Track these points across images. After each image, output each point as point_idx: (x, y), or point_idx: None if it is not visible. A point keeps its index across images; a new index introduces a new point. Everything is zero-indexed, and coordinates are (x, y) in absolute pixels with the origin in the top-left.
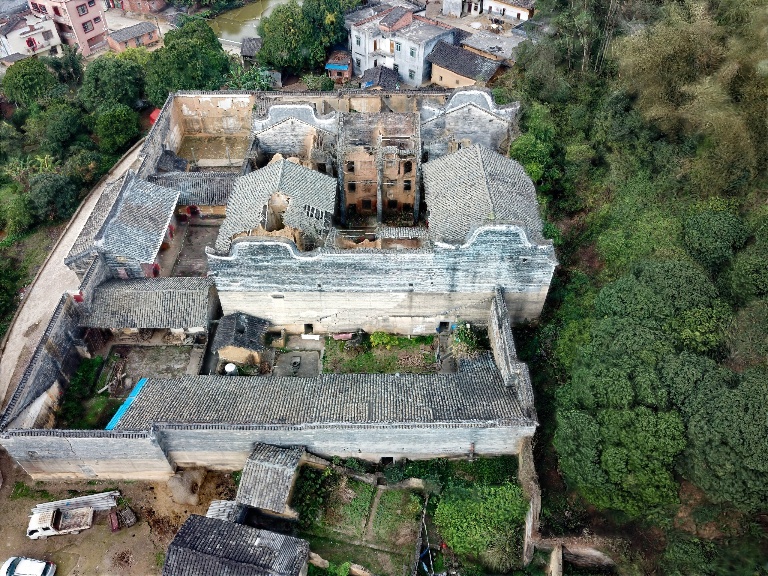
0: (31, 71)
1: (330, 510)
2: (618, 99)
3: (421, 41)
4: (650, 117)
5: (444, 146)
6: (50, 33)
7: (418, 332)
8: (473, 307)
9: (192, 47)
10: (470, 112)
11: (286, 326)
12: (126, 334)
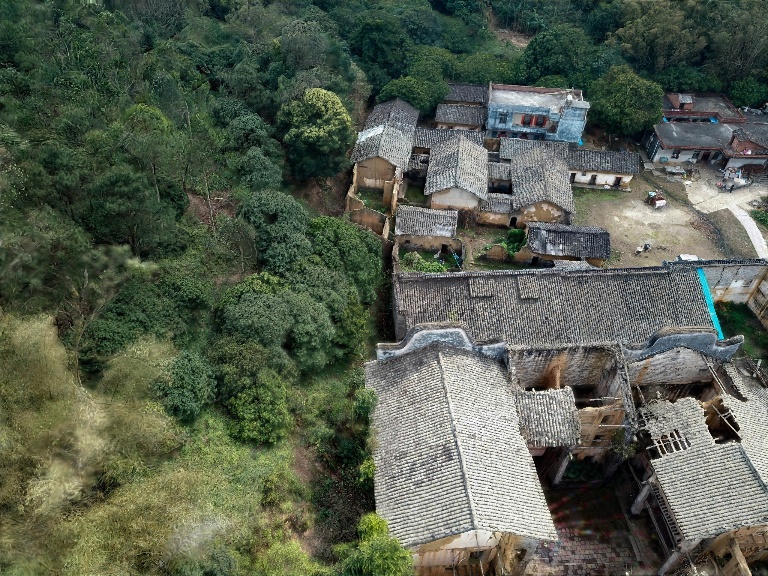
0: None
1: None
2: None
3: None
4: None
5: None
6: None
7: None
8: None
9: None
10: None
11: None
12: None
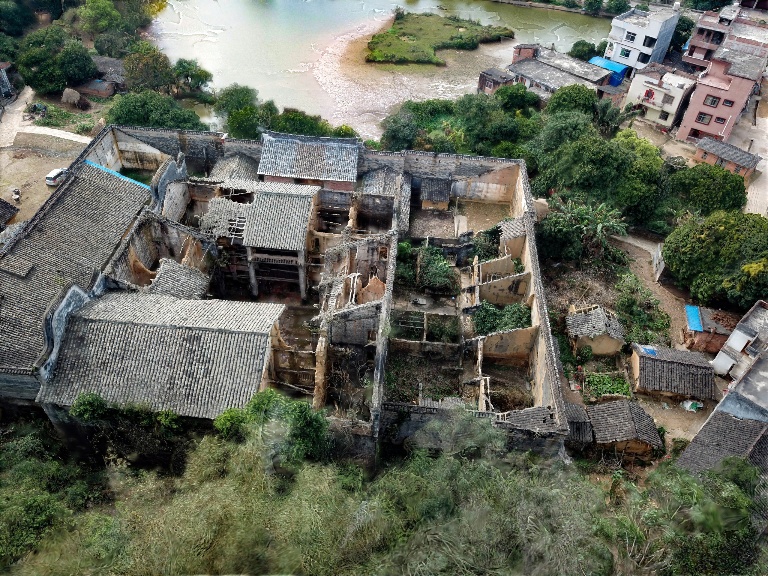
0: (572, 95)
1: None
2: None
3: None
4: None
5: None
6: (672, 99)
7: None
8: None
9: (611, 158)
10: None
11: None
12: None
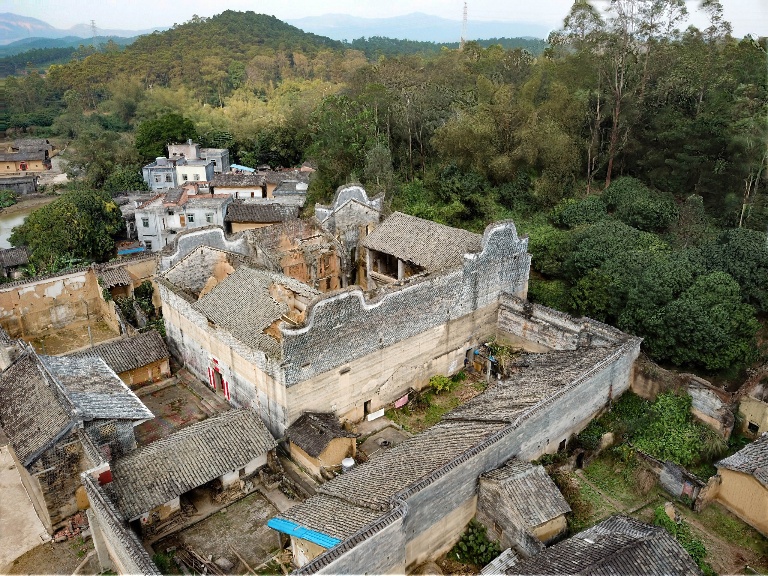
0: None
1: (577, 505)
2: (453, 169)
3: (216, 206)
4: (494, 165)
5: (356, 232)
6: None
7: (451, 372)
8: (487, 323)
9: None
10: (352, 208)
11: (348, 415)
12: (163, 520)
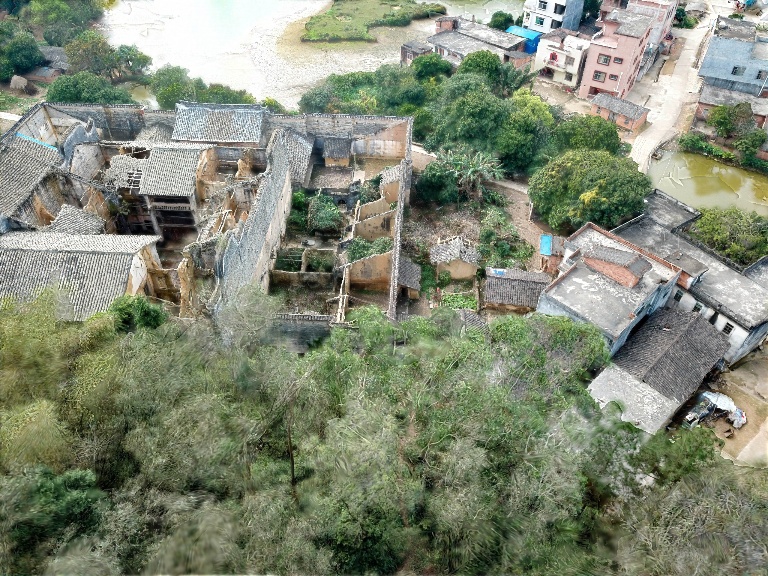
0: (476, 60)
1: None
2: None
3: None
4: None
5: None
6: (573, 61)
7: None
8: None
9: (488, 111)
10: None
11: None
12: None
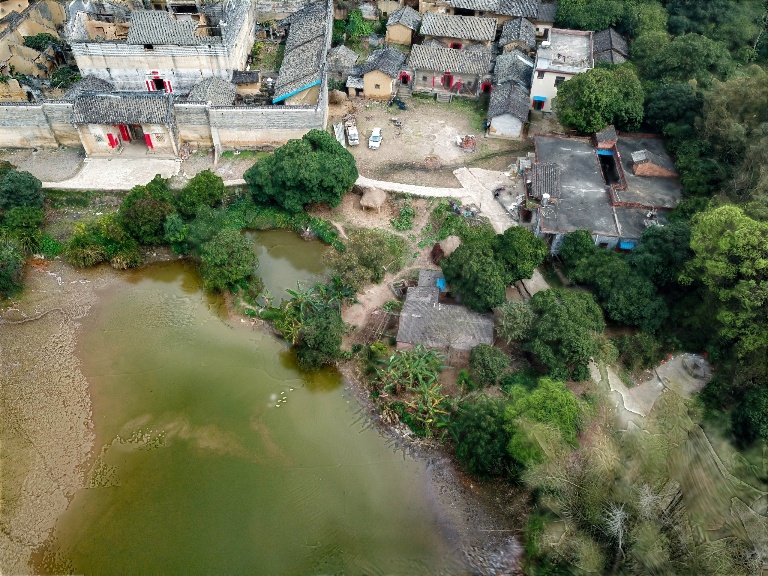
0: None
1: None
2: None
3: None
4: None
5: None
6: None
7: None
8: None
9: None
10: None
11: None
12: None
